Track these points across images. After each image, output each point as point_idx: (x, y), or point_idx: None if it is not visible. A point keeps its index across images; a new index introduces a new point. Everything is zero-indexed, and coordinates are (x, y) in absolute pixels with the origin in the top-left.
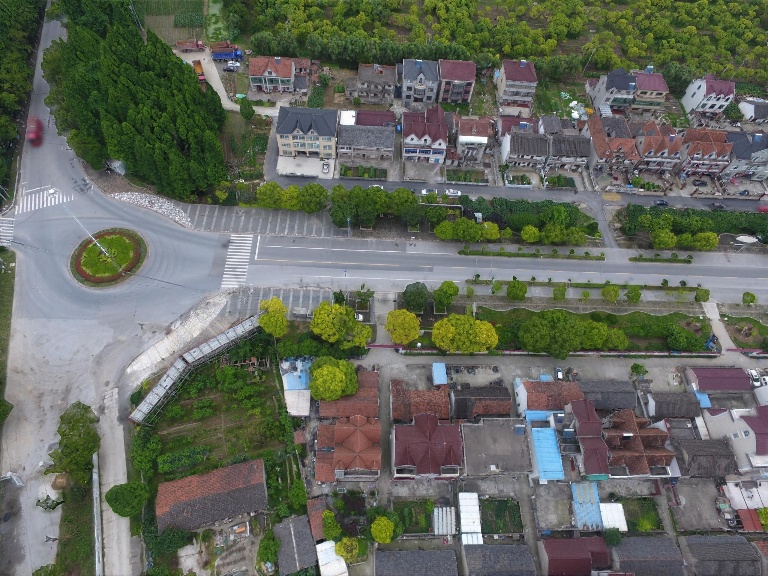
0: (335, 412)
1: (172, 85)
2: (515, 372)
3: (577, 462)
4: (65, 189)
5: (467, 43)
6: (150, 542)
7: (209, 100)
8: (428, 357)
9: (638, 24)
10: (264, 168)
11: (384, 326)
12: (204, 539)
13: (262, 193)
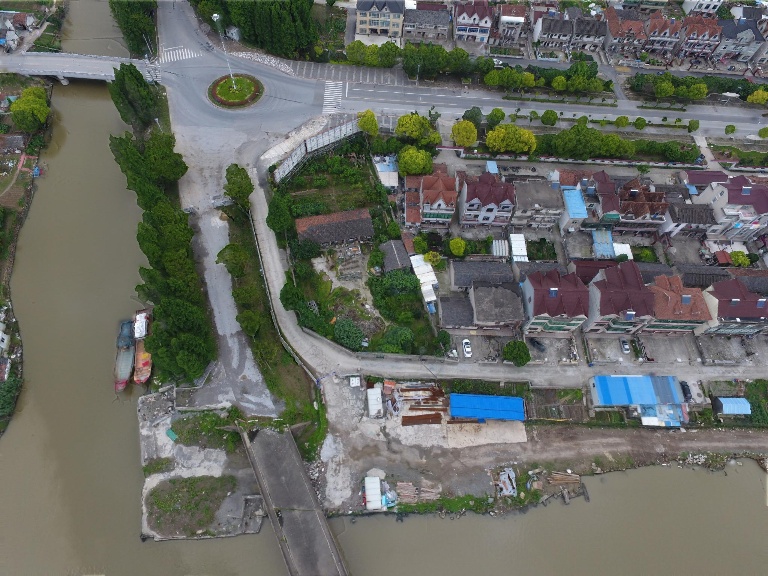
0: (417, 185)
1: None
2: (548, 172)
3: (597, 212)
4: (194, 49)
5: None
6: (294, 248)
7: None
8: (482, 161)
9: None
10: (345, 42)
11: (448, 140)
12: (330, 251)
13: (351, 48)
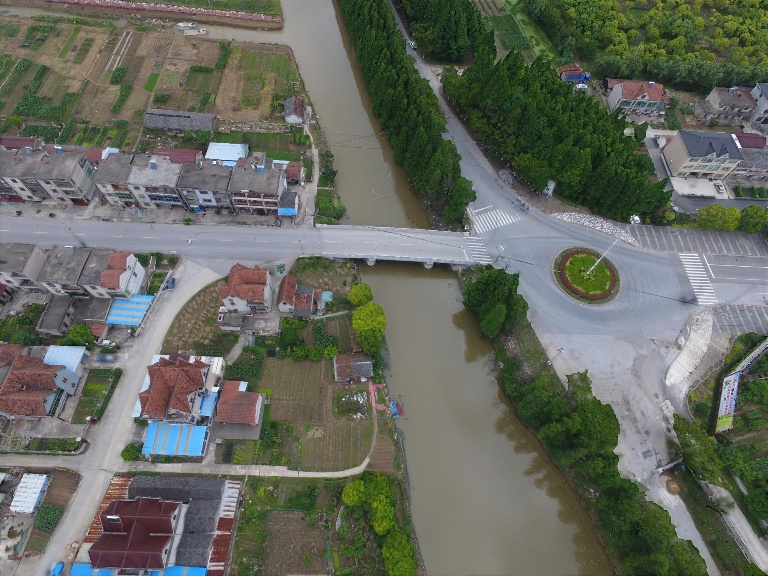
0: None
1: (591, 110)
2: None
3: None
4: (507, 209)
5: None
6: None
7: (621, 124)
8: None
9: None
10: None
11: None
12: None
13: (712, 215)
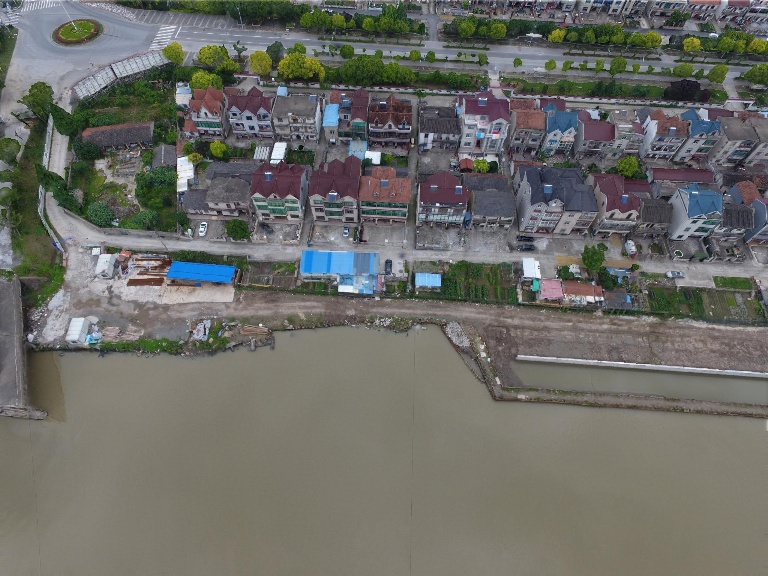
0: None
1: None
2: None
3: None
4: (55, 0)
5: None
6: (77, 149)
7: None
8: None
9: None
10: None
11: None
12: (110, 154)
13: None
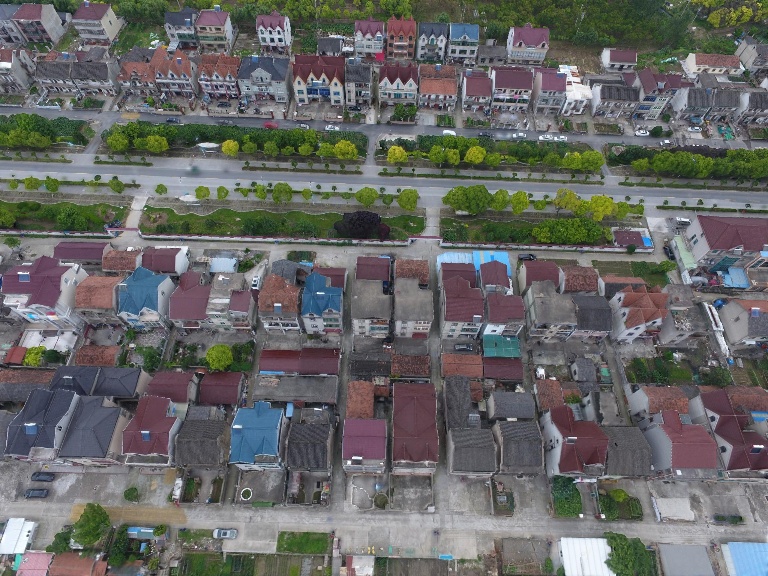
0: None
1: None
2: None
3: None
4: None
5: None
6: None
7: None
8: None
9: None
10: None
11: None
12: None
13: None
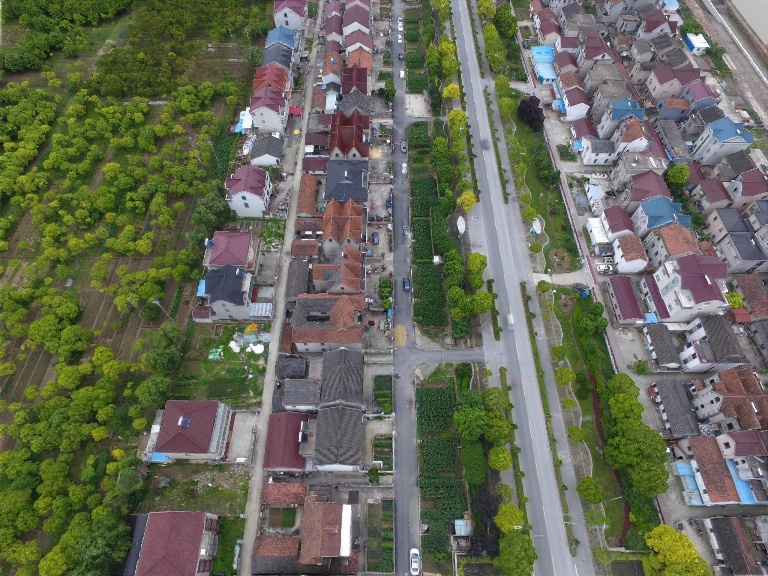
0: None
1: None
2: (674, 501)
3: None
4: None
5: (64, 509)
6: None
7: None
8: None
9: (78, 223)
10: None
11: None
12: None
13: None
